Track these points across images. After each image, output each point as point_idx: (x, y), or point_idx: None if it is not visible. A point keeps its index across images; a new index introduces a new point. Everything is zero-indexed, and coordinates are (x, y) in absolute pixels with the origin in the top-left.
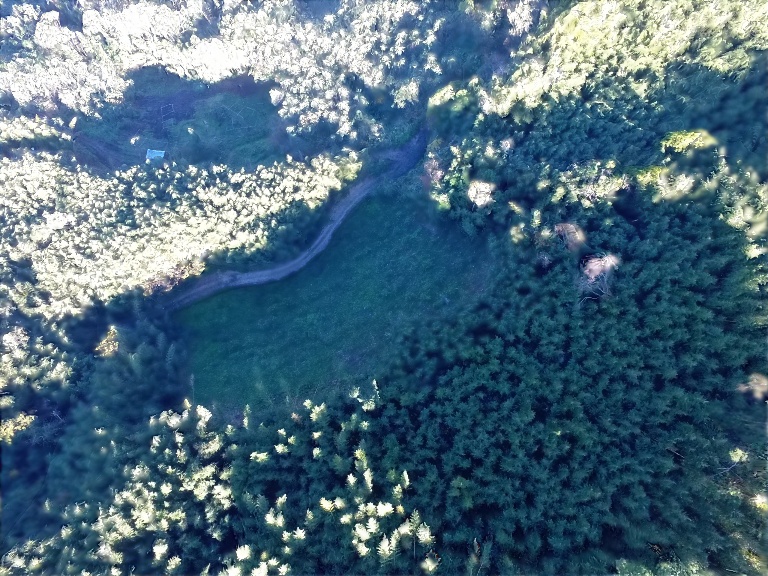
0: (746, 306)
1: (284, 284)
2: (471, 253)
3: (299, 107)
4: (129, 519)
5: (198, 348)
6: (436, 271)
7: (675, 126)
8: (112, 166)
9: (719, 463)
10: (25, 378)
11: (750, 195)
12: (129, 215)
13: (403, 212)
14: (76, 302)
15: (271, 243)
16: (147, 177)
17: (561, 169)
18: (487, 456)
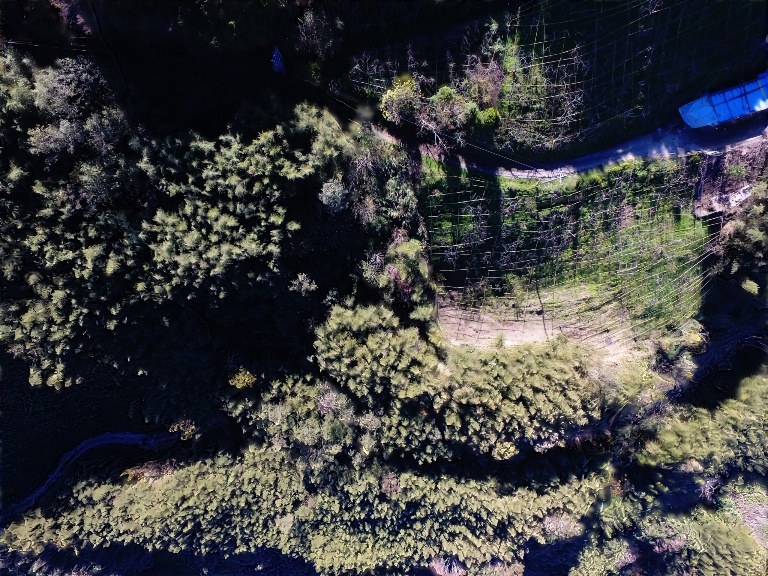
0: None
1: None
2: None
3: None
4: None
5: None
6: None
7: None
8: None
9: None
10: None
11: None
12: None
13: None
14: None
15: None
16: None
17: None
18: None
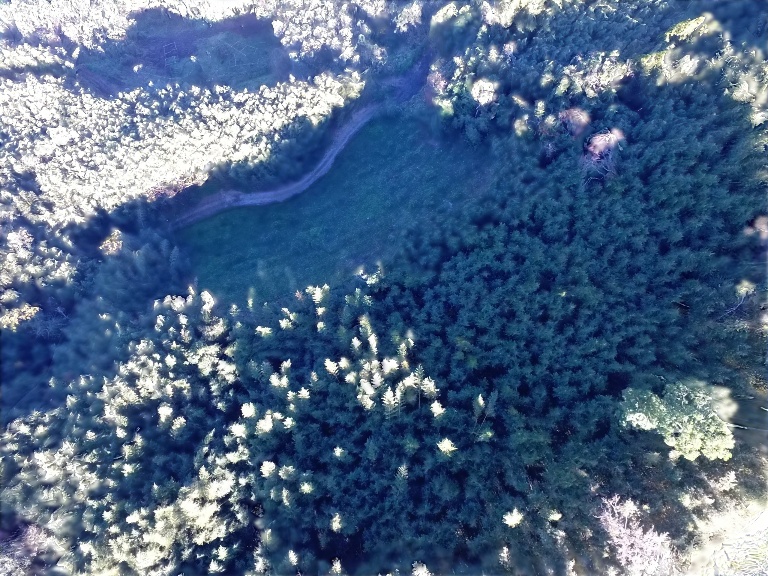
0: (752, 167)
1: (287, 204)
2: (474, 161)
3: (302, 34)
4: (134, 388)
5: (201, 262)
6: (439, 180)
7: (679, 21)
8: (115, 93)
9: (725, 306)
10: (29, 276)
11: (755, 71)
12: (132, 130)
13: (406, 131)
14: (80, 212)
15: (274, 155)
16: (150, 97)
17: (565, 64)
18: (492, 325)
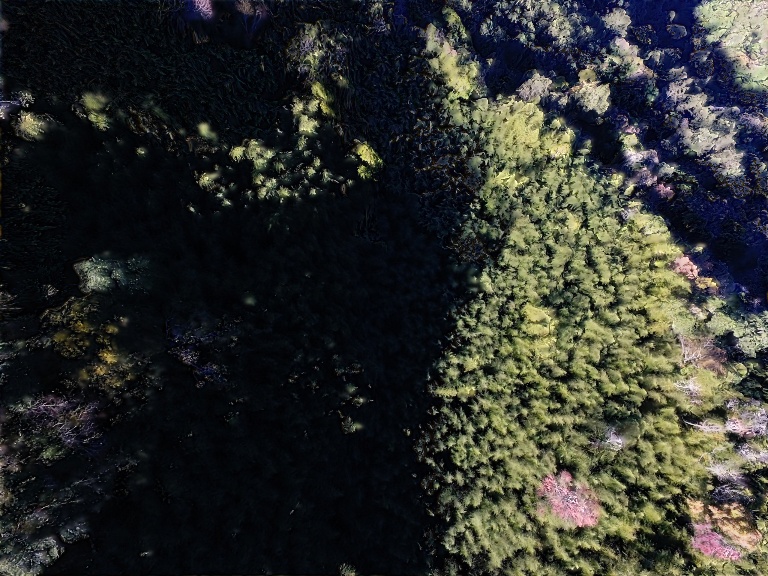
0: None
1: None
2: None
3: None
4: None
5: None
6: None
7: (394, 179)
8: None
9: None
10: None
11: None
12: None
13: None
14: None
15: None
16: None
17: None
18: None
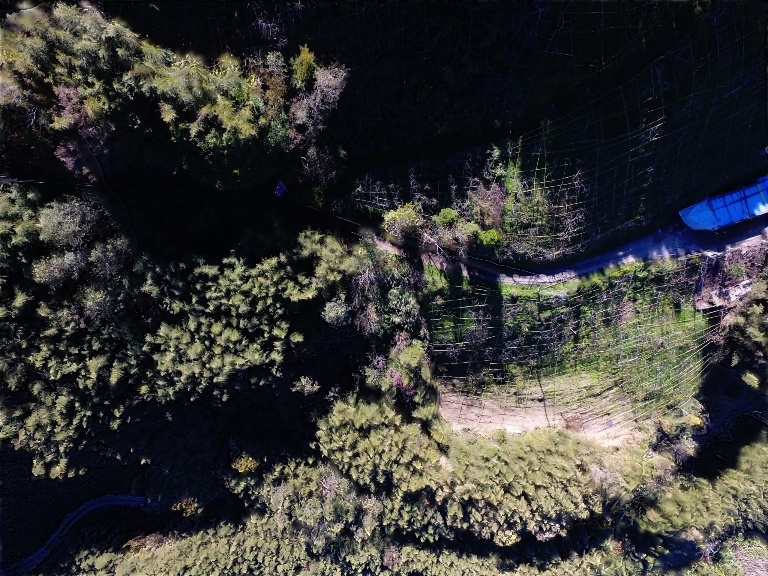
0: None
1: None
2: None
3: None
4: None
5: None
6: None
7: None
8: None
9: None
10: None
11: None
12: None
13: None
14: None
15: None
16: None
17: None
18: None
